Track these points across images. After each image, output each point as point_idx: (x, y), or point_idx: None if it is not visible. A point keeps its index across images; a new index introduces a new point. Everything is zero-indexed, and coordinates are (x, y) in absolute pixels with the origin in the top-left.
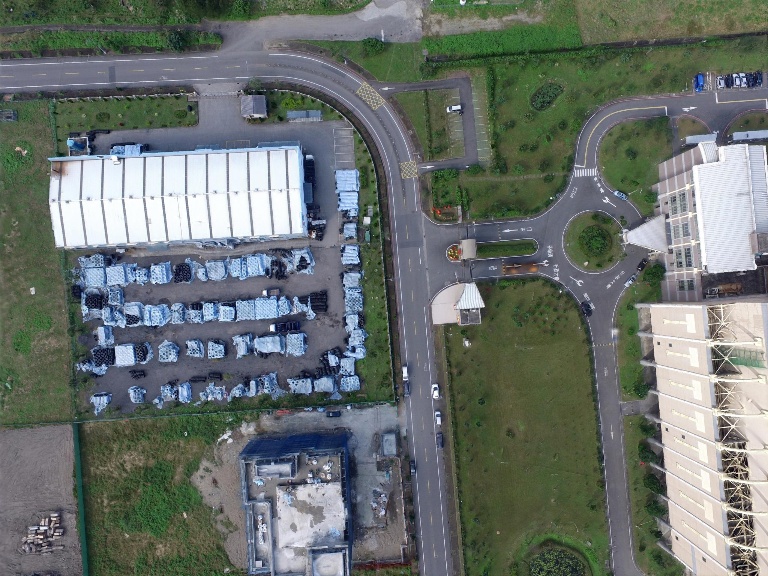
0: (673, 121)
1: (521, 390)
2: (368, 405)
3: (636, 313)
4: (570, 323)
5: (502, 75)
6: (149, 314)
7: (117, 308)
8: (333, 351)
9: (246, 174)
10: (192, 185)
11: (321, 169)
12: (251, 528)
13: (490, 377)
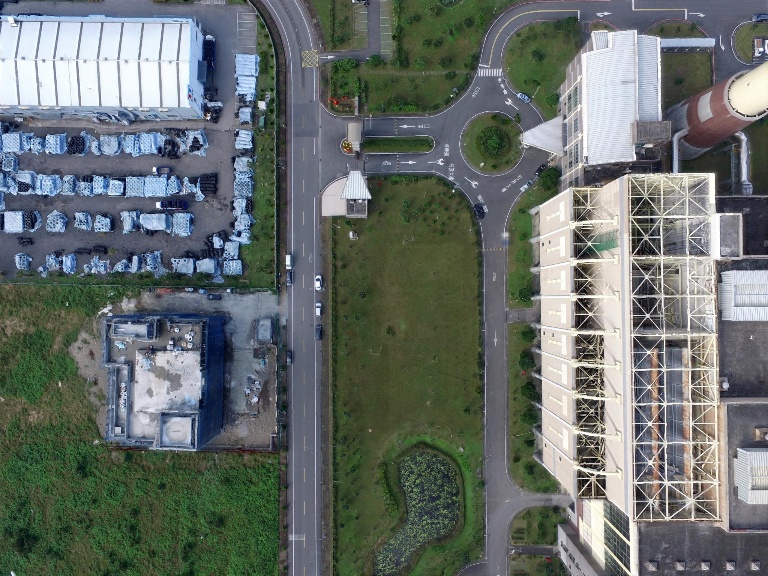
0: (585, 26)
1: (405, 288)
2: (250, 291)
3: (530, 219)
4: (461, 224)
5: None
6: (40, 182)
7: (11, 175)
8: (218, 234)
9: (138, 44)
10: (84, 51)
11: (222, 52)
12: (114, 394)
13: (375, 273)
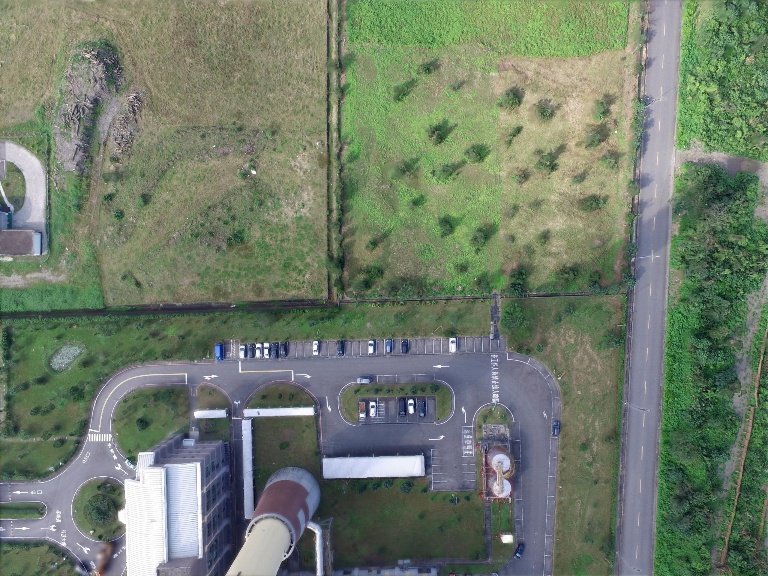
0: (193, 389)
1: None
2: None
3: None
4: None
5: (21, 334)
6: None
7: None
8: None
9: None
10: None
11: None
12: None
13: None
